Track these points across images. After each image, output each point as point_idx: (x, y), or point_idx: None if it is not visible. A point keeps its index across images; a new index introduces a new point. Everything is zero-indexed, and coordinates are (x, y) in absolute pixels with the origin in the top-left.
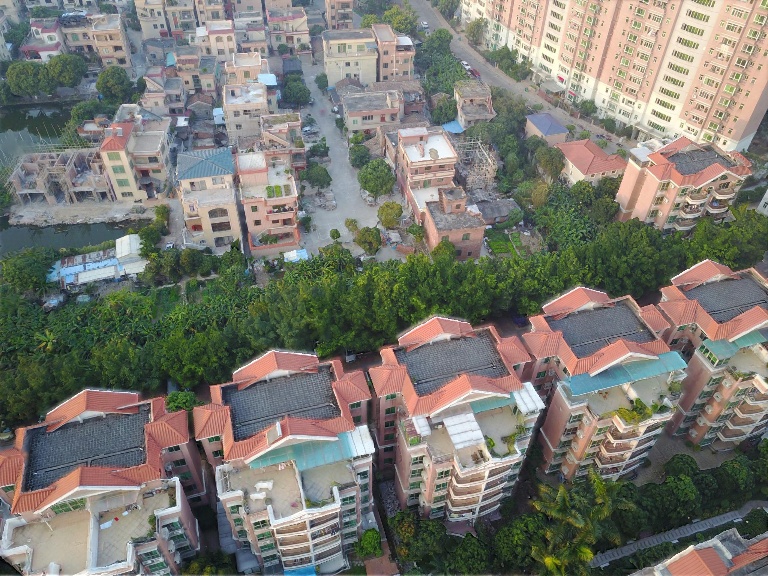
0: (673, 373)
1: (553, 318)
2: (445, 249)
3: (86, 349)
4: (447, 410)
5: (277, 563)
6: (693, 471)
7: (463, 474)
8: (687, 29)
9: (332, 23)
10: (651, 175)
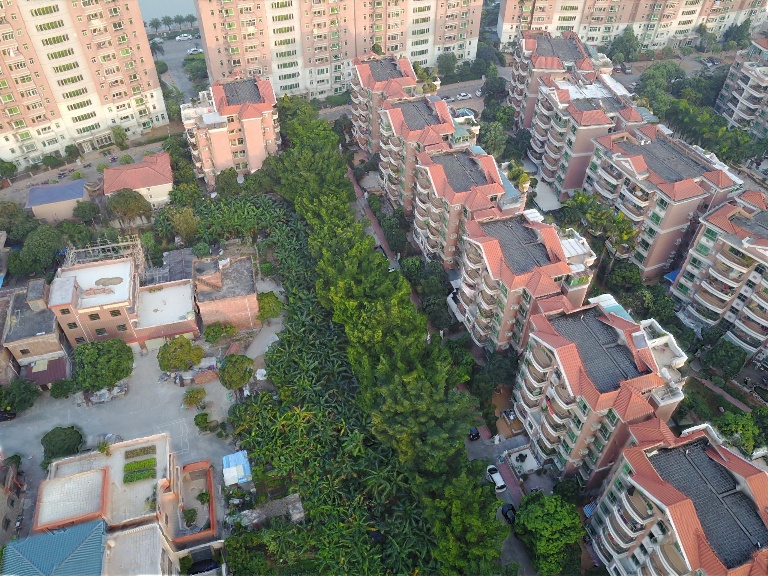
0: None
1: None
2: (272, 298)
3: None
4: None
5: None
6: None
7: None
8: (45, 28)
9: None
10: (251, 120)
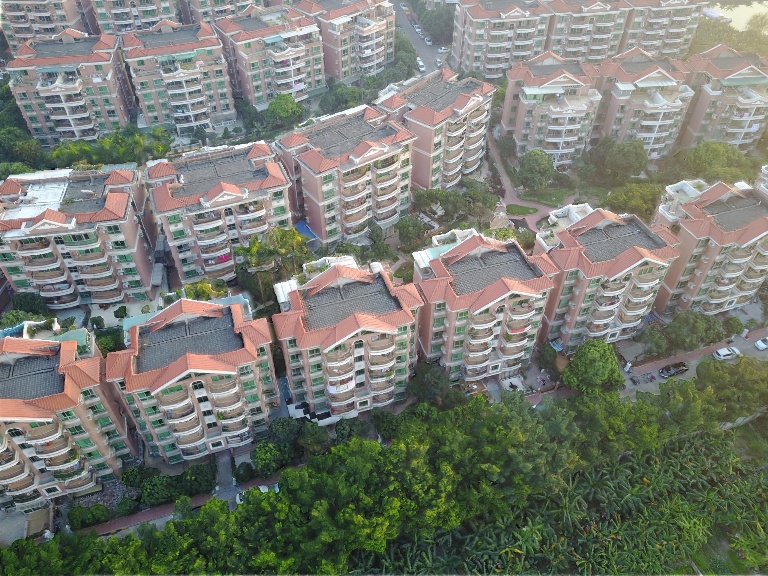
0: None
1: None
2: None
3: (764, 476)
4: None
5: None
6: None
7: None
8: None
9: None
10: None
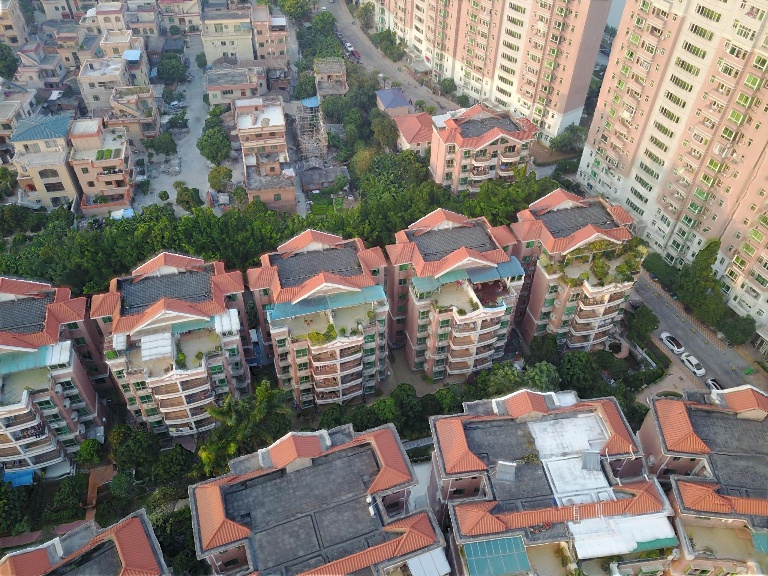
0: (375, 304)
1: (281, 257)
2: (254, 208)
3: None
4: (148, 330)
5: (1, 466)
6: (408, 397)
7: (150, 384)
8: (513, 7)
9: (232, 7)
10: (440, 139)
